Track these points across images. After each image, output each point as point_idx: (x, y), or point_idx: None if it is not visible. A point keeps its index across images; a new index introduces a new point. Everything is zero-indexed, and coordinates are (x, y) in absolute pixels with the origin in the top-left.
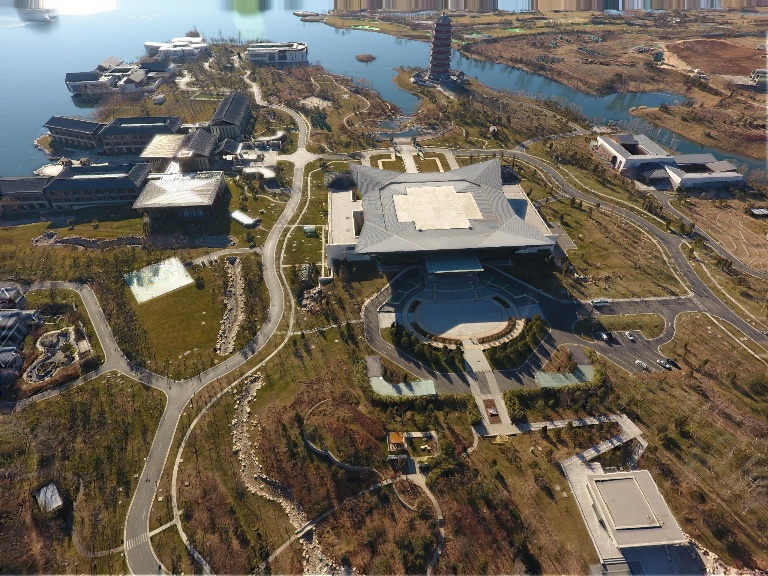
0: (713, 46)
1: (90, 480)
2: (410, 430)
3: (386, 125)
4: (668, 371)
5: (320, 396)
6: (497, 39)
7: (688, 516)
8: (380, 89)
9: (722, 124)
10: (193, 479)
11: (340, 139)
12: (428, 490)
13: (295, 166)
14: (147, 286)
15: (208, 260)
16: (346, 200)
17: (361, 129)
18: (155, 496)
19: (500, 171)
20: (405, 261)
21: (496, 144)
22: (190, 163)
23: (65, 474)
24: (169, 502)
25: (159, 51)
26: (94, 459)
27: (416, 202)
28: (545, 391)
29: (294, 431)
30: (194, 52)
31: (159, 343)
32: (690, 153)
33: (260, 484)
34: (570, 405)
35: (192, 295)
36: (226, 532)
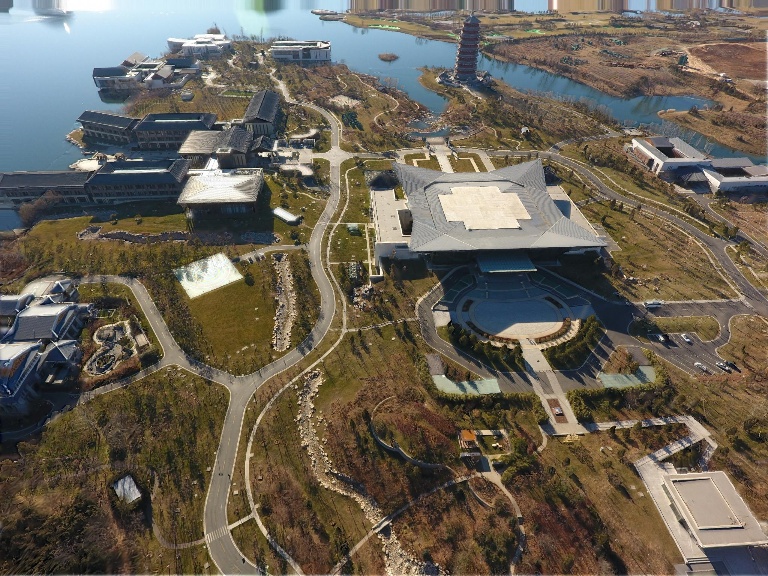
0: (736, 50)
1: (165, 473)
2: (479, 428)
3: (416, 124)
4: (728, 373)
5: (384, 393)
6: (519, 40)
7: (765, 517)
8: (406, 88)
9: (754, 128)
10: (265, 473)
11: (373, 138)
12: (504, 488)
13: (331, 164)
14: (197, 281)
15: (255, 256)
16: (389, 199)
17: (392, 128)
18: (230, 490)
19: (543, 172)
20: (455, 260)
21: (529, 145)
22: (229, 159)
23: (139, 466)
24: (245, 496)
25: (183, 47)
26: (165, 452)
27: (462, 202)
28: (609, 391)
29: (362, 427)
30: (217, 49)
31: (215, 338)
32: (723, 157)
33: (332, 479)
34: (635, 406)
35: (243, 291)
36: (306, 526)
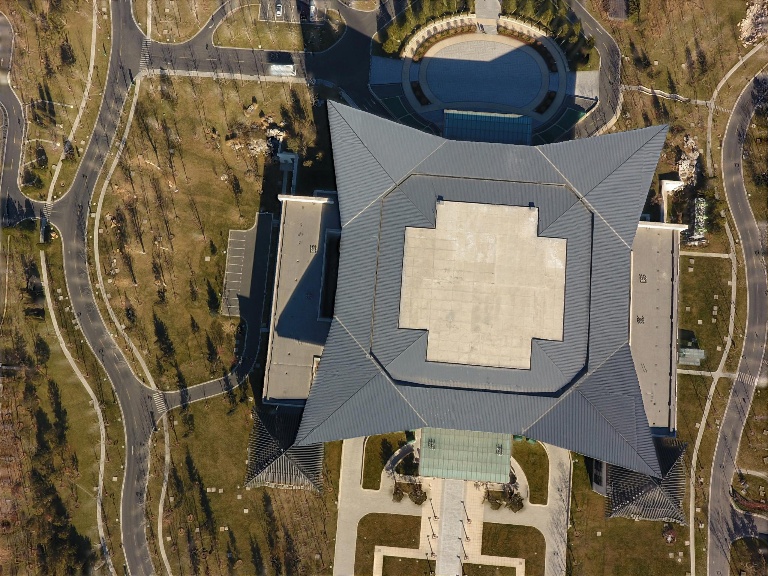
0: None
1: None
2: None
3: None
4: None
5: None
6: None
7: None
8: None
9: None
10: None
11: None
12: None
13: None
14: None
15: None
16: None
17: None
18: None
19: (313, 389)
20: None
21: None
22: None
23: None
24: None
25: None
26: None
27: (521, 303)
28: None
29: None
30: None
31: None
32: None
33: None
34: None
35: None
36: None
